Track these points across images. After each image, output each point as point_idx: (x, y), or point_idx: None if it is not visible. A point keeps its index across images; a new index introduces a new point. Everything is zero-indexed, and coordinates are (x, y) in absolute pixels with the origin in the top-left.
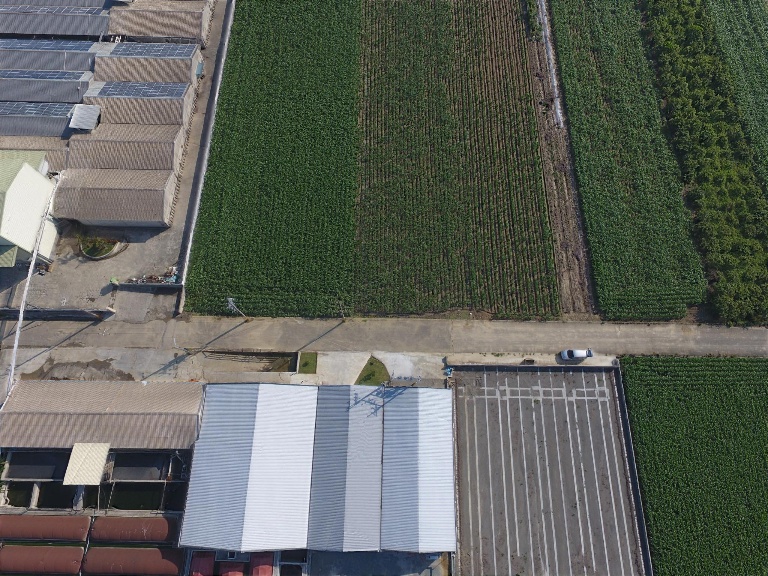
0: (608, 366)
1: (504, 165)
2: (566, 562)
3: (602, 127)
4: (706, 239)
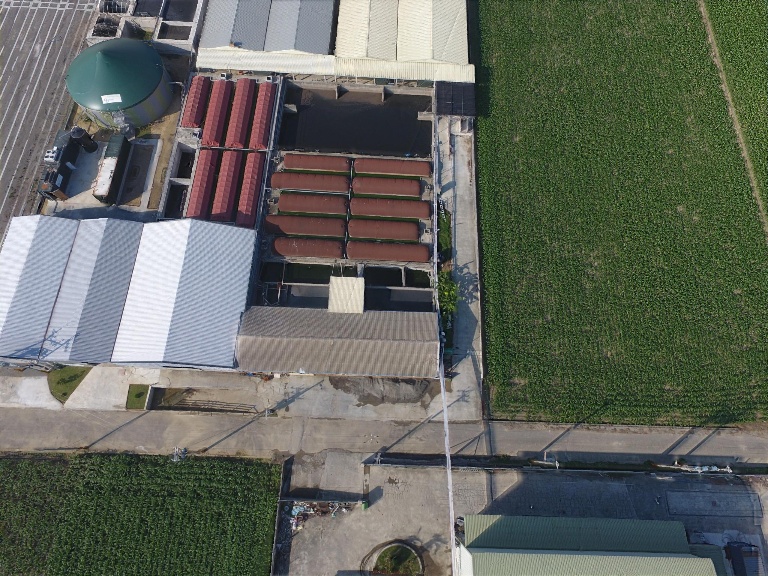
0: None
1: None
2: None
3: None
4: None
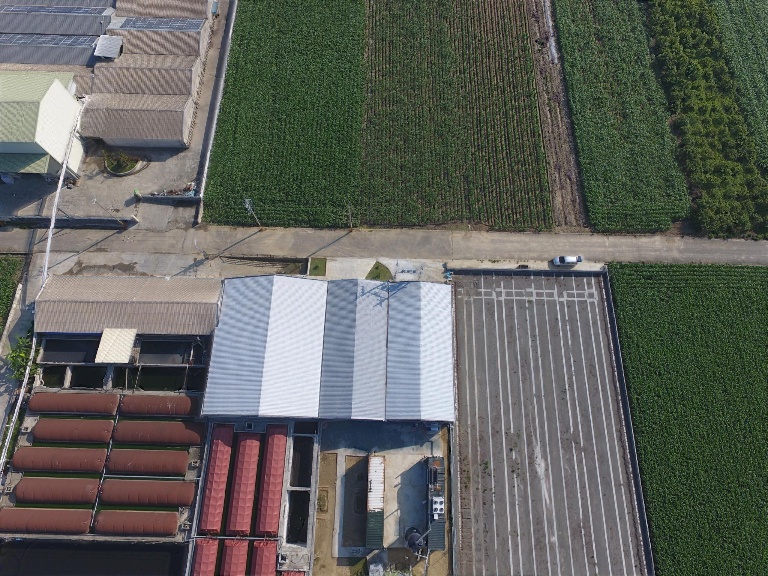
0: (597, 270)
1: (501, 96)
2: (556, 438)
3: (594, 62)
4: (690, 161)
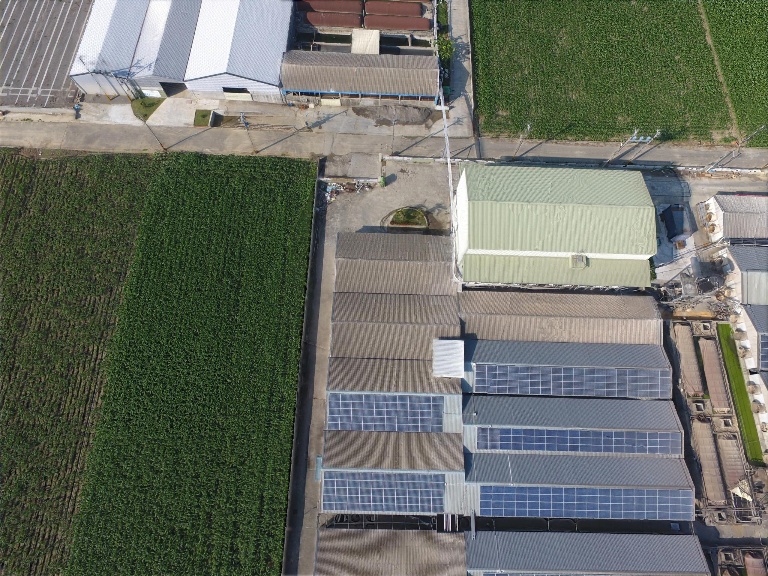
0: None
1: None
2: None
3: None
4: None
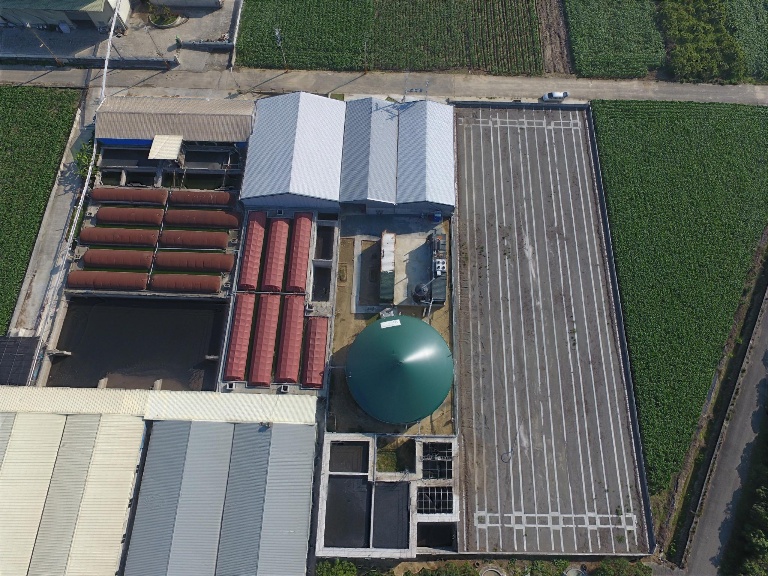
0: (581, 104)
1: None
2: (542, 230)
3: None
4: (666, 21)
